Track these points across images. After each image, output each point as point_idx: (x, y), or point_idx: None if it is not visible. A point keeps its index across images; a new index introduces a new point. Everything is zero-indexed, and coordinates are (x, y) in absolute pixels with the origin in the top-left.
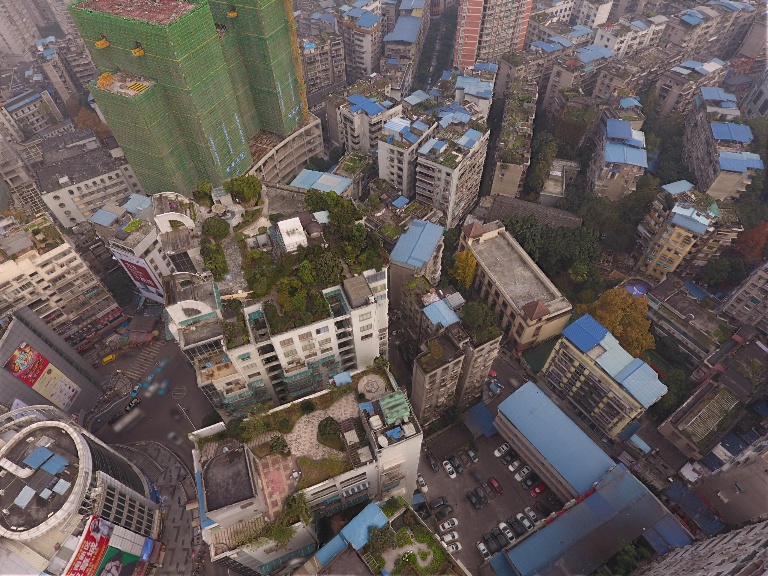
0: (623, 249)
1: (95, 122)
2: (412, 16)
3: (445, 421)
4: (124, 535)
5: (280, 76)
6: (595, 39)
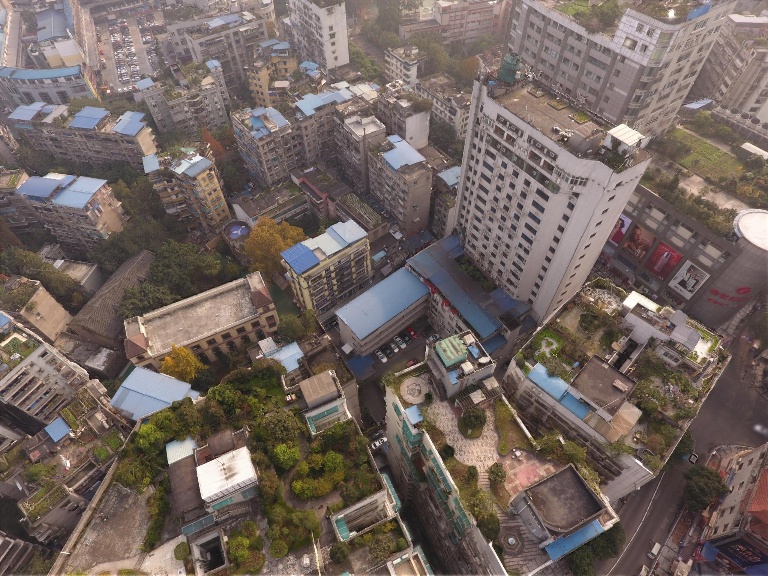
0: None
1: None
2: None
3: None
4: None
5: None
6: None
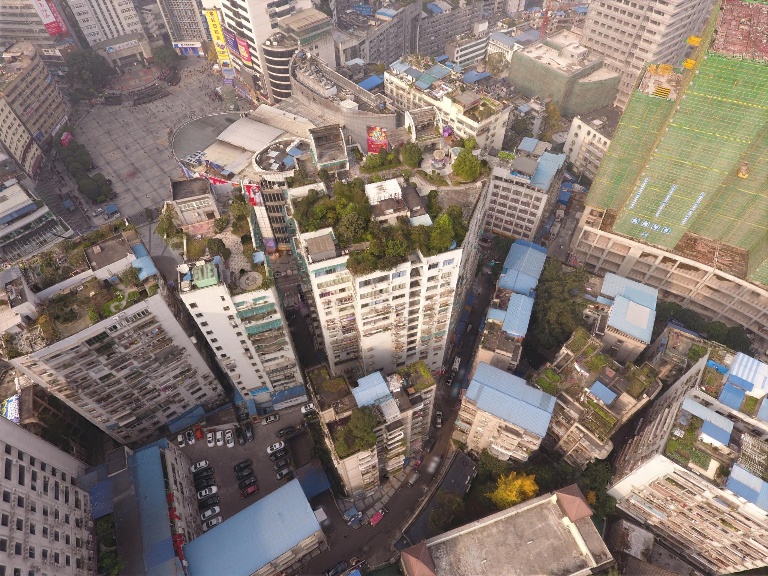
0: None
1: None
2: None
3: None
4: (264, 217)
5: None
6: None
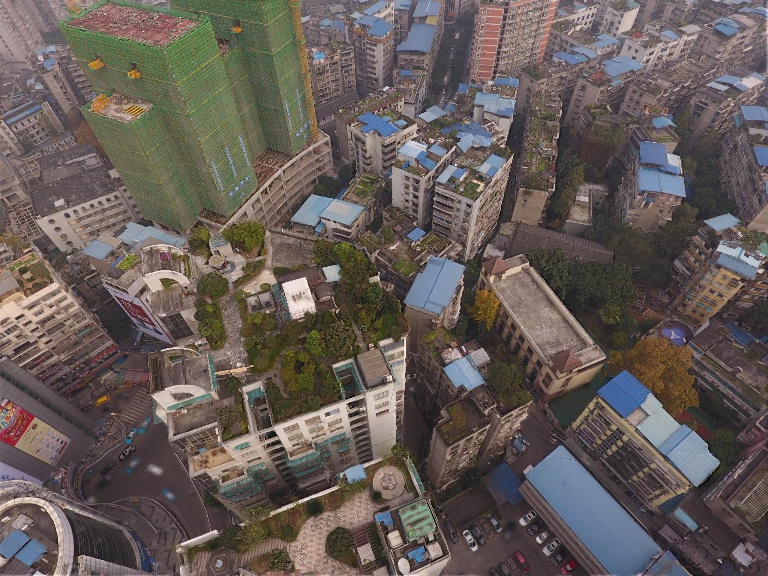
0: (657, 285)
1: (95, 137)
2: (426, 24)
3: (465, 482)
4: None
5: (287, 94)
6: (622, 50)
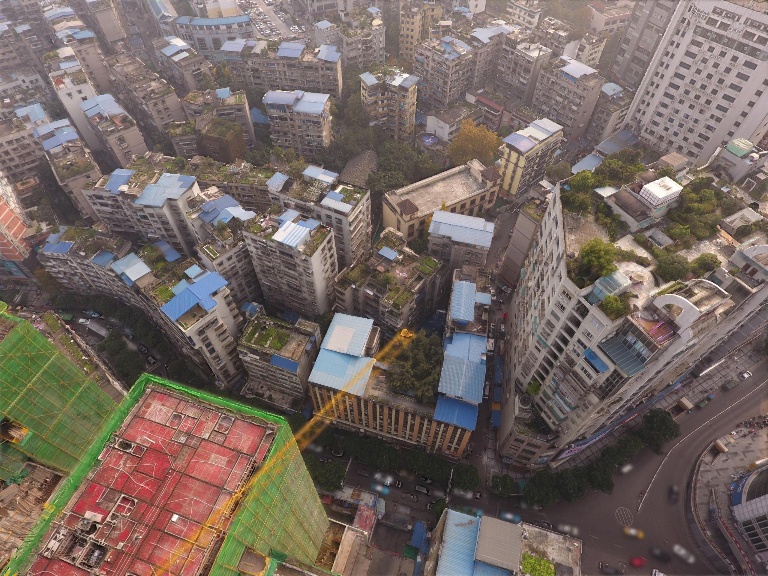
0: None
1: None
2: None
3: None
4: None
5: None
6: (64, 103)
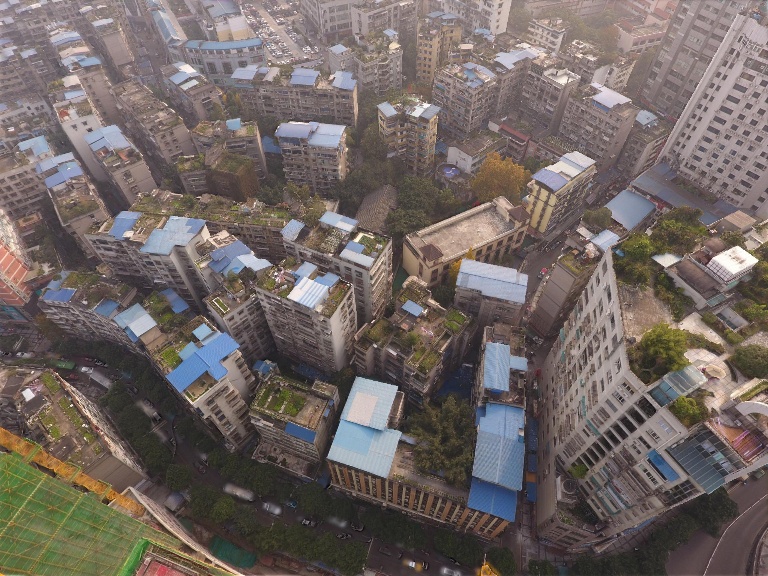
0: None
1: None
2: None
3: None
4: None
5: None
6: (68, 135)
